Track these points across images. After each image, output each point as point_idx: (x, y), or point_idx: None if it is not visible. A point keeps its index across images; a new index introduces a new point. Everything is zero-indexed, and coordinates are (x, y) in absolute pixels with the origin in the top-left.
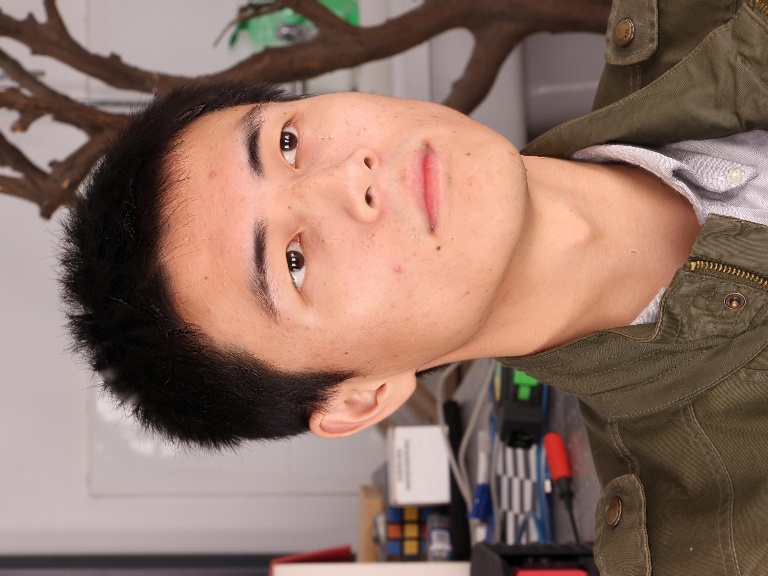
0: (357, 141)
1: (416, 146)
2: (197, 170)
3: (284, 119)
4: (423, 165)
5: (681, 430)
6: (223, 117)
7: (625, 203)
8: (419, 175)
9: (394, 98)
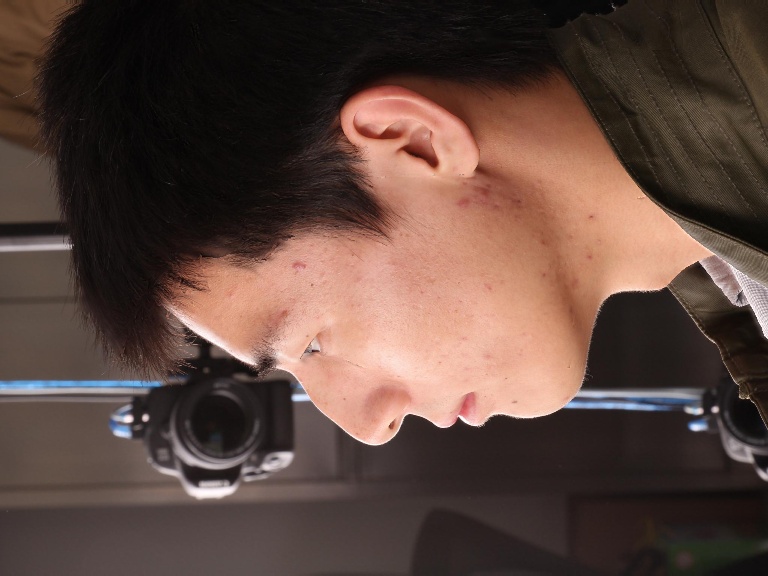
0: (388, 378)
1: (454, 406)
2: None
3: (305, 348)
4: None
5: None
6: (234, 292)
7: None
8: None
9: (447, 313)
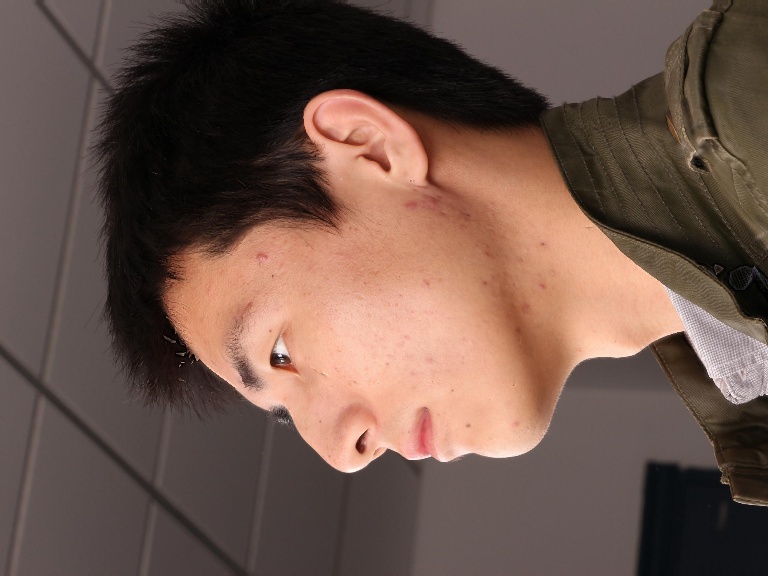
0: (350, 390)
1: (410, 423)
2: (198, 348)
3: (270, 345)
4: (420, 441)
5: None
6: (210, 287)
7: None
8: (417, 456)
9: (387, 305)
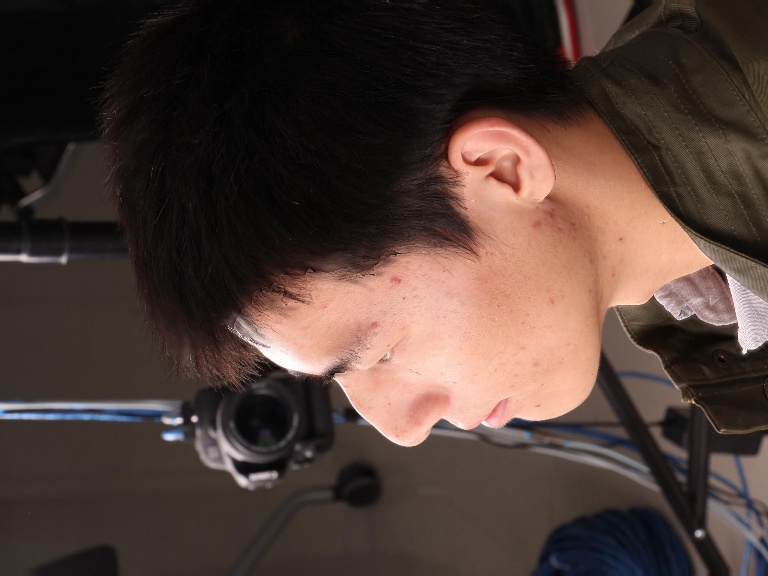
0: None
1: (490, 410)
2: None
3: None
4: None
5: None
6: (329, 305)
7: (708, 263)
8: None
9: (516, 324)
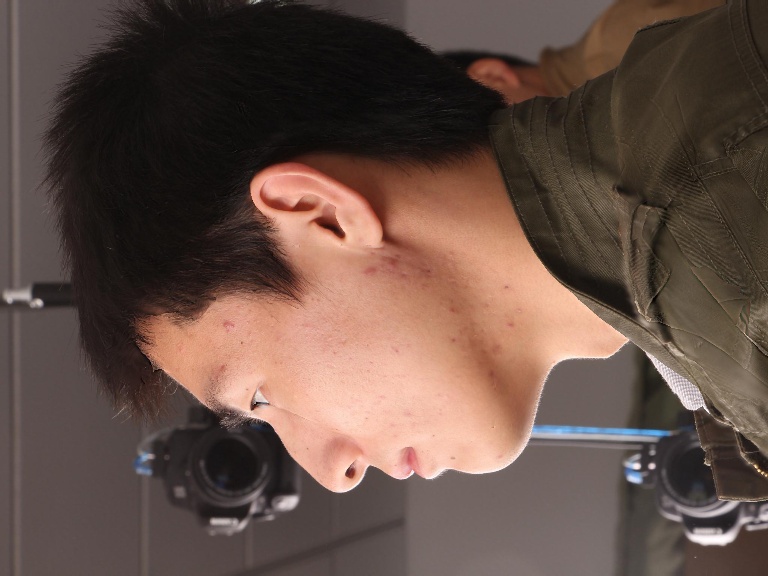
0: None
1: (395, 460)
2: None
3: (249, 400)
4: (408, 468)
5: (761, 262)
6: (182, 347)
7: None
8: None
9: (359, 372)
